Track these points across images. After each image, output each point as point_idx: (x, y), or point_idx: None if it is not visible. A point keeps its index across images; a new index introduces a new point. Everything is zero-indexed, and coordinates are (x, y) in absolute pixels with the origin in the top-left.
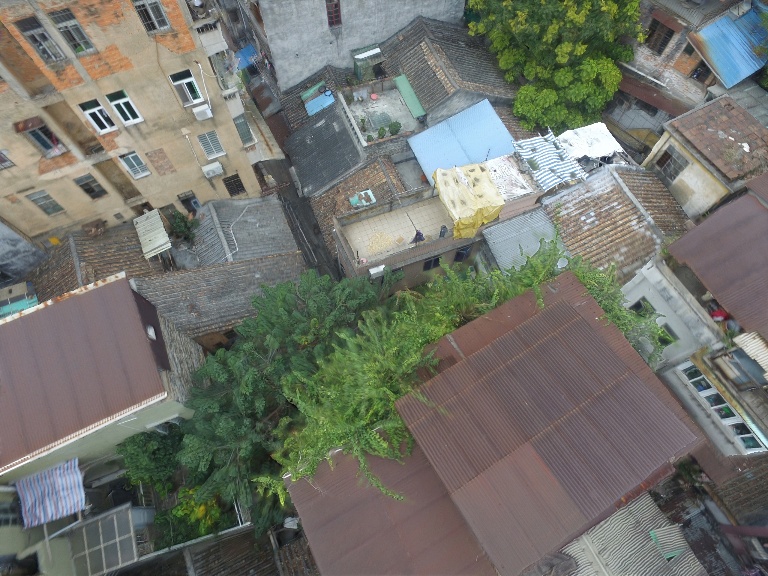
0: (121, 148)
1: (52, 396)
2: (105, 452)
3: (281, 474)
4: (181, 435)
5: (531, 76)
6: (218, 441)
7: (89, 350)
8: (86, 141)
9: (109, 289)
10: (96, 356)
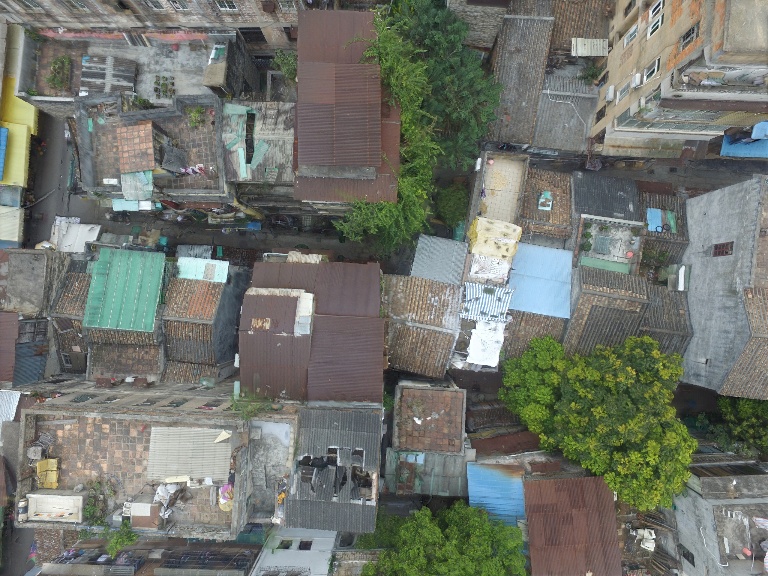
0: None
1: None
2: None
3: None
4: None
5: None
6: None
7: None
8: None
9: None
10: None
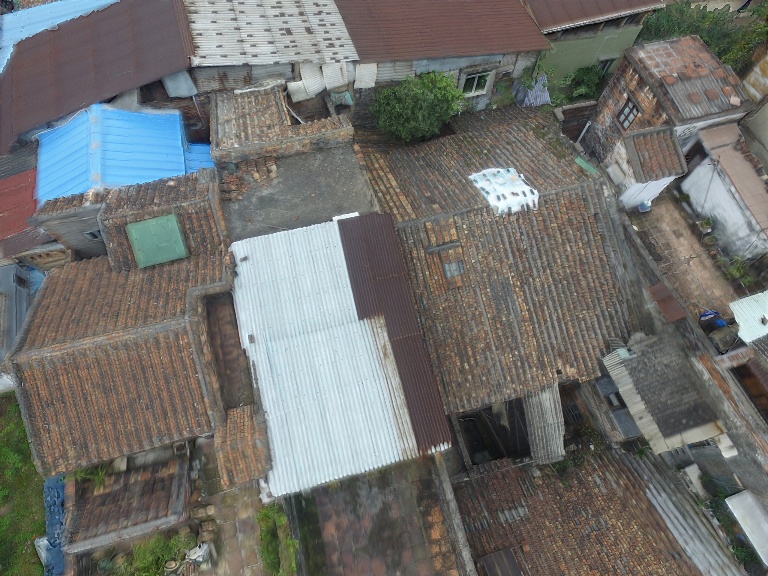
0: None
1: None
2: (552, 84)
3: (765, 38)
4: None
5: None
6: None
7: None
8: None
9: None
10: None
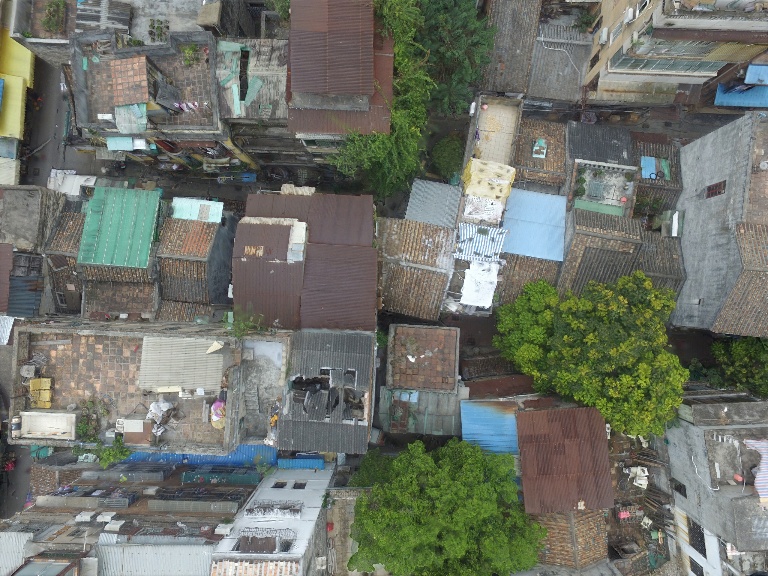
0: None
1: None
2: None
3: None
4: None
5: None
6: None
7: None
8: None
9: None
10: None
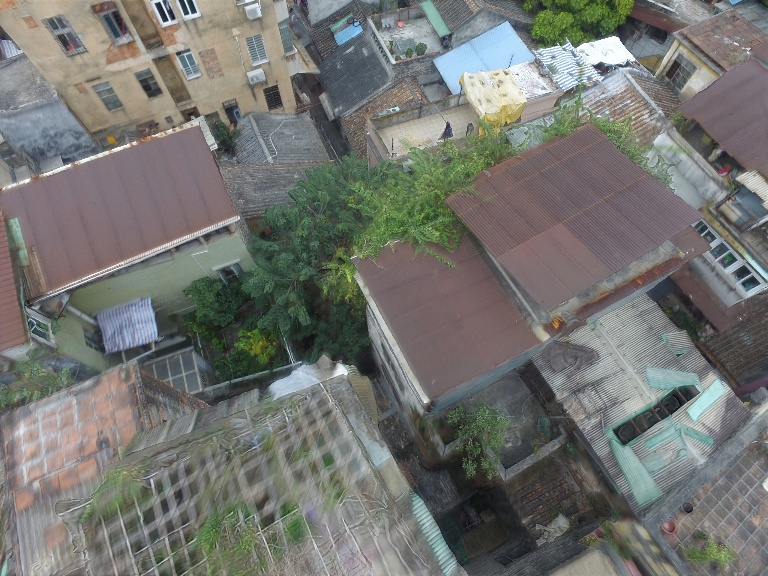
0: (178, 44)
1: (140, 217)
2: None
3: None
4: (238, 289)
5: (549, 2)
6: (278, 276)
7: (171, 182)
8: (147, 38)
9: (185, 135)
10: (177, 187)
